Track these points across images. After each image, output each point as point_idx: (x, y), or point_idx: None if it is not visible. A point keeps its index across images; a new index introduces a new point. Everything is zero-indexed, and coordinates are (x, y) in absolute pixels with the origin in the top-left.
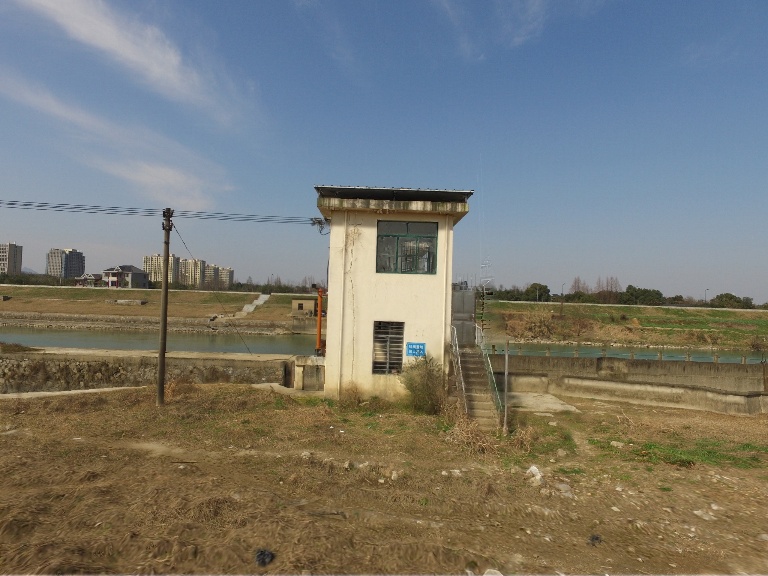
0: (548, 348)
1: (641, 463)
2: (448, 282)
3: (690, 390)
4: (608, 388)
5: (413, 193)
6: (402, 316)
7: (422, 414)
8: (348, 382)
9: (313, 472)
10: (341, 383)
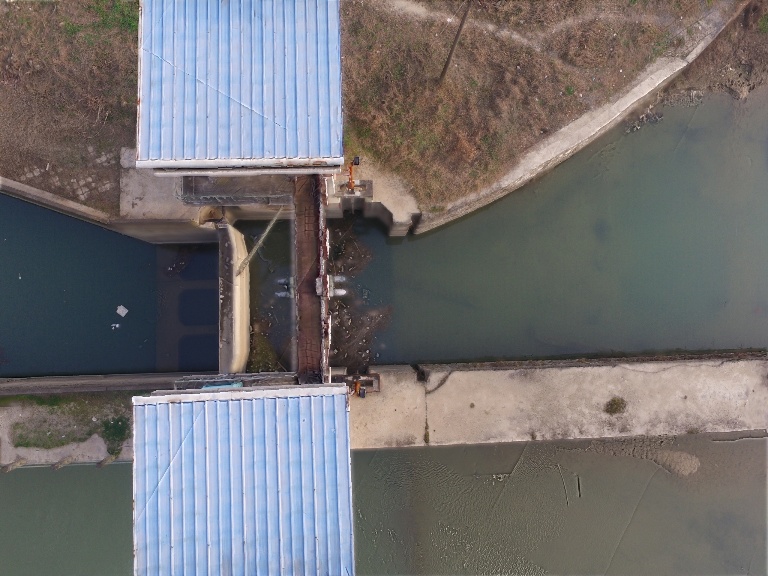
0: (6, 466)
1: None
2: None
3: None
4: None
5: None
6: None
7: None
8: None
9: None
10: None
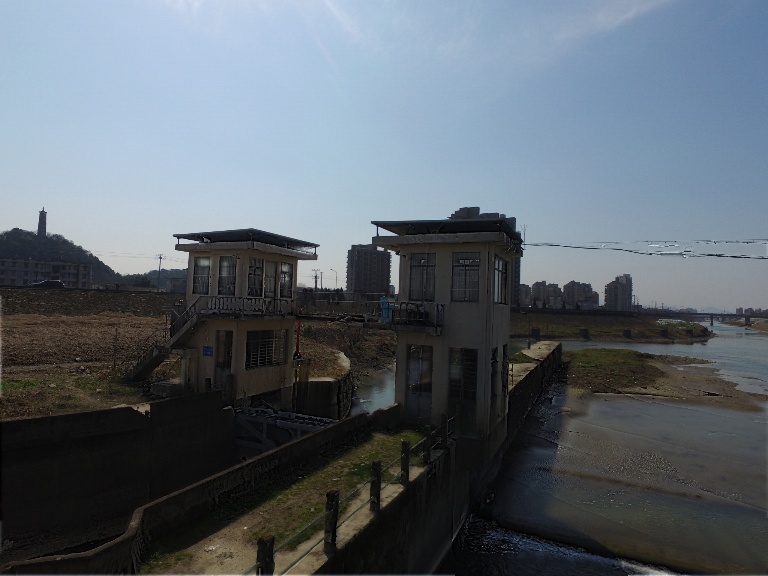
0: (329, 493)
1: (40, 379)
2: None
3: None
4: (67, 426)
5: None
6: None
7: None
8: None
9: None
10: None
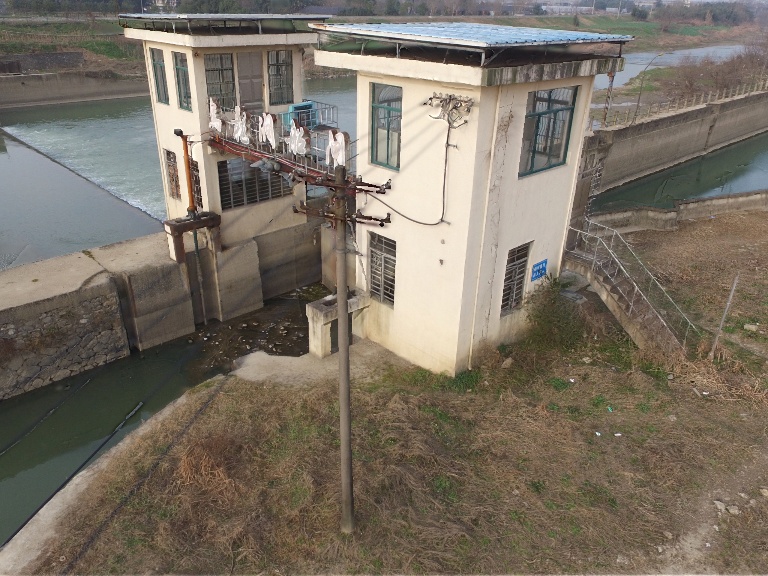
0: None
1: None
2: (577, 172)
3: (636, 212)
4: None
5: (579, 44)
6: (534, 233)
7: (560, 347)
8: (479, 341)
9: (767, 526)
10: (473, 347)
